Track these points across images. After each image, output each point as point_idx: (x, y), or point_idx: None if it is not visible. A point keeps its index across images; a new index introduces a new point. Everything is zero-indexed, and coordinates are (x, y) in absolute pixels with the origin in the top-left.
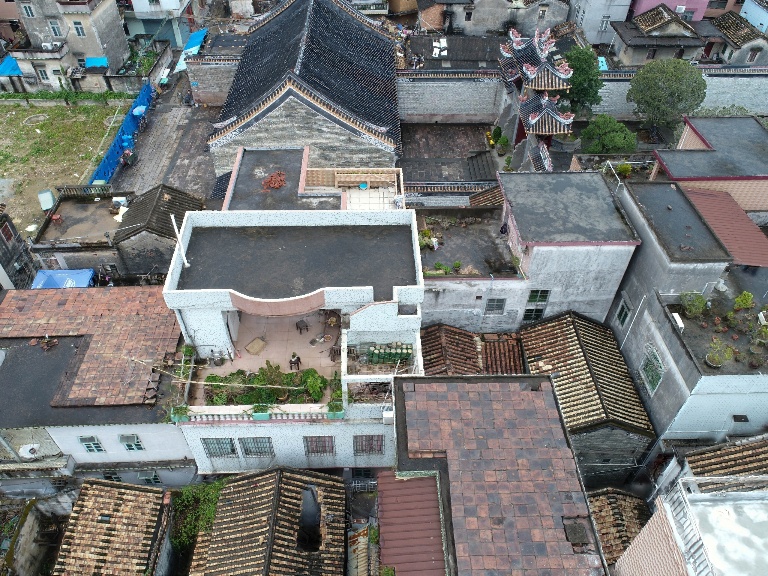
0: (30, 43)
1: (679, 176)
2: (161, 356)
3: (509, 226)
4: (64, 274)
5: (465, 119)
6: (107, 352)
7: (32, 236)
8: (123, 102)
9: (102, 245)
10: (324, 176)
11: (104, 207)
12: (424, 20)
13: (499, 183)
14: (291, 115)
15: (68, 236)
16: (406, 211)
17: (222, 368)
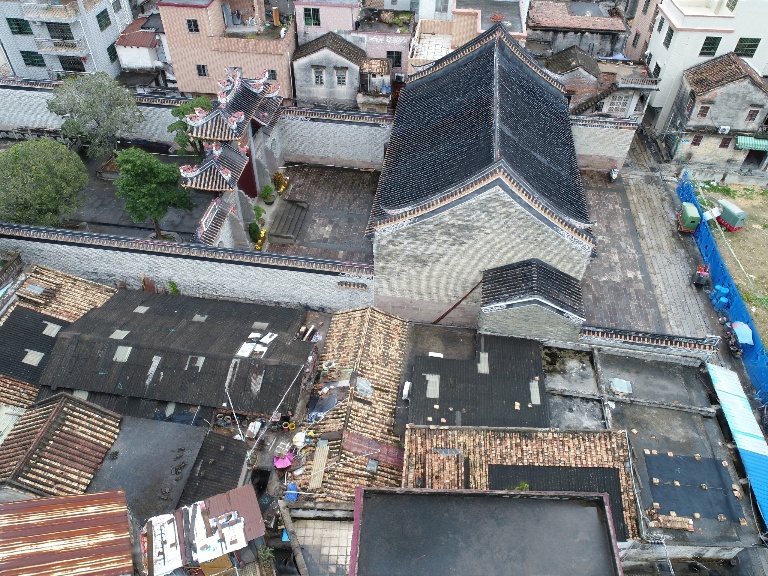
0: None
1: None
2: (534, 8)
3: None
4: None
5: None
6: None
7: None
8: None
9: None
10: None
11: None
12: None
13: None
14: None
15: (629, 69)
16: None
17: None
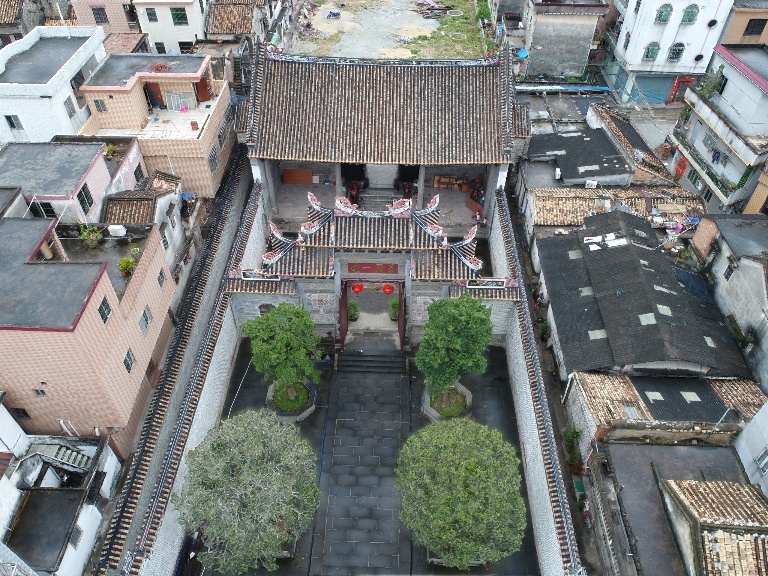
0: None
1: (2, 221)
2: None
3: None
4: None
5: None
6: None
7: None
8: None
9: None
10: None
11: None
12: (699, 230)
13: None
14: None
15: (205, 49)
16: (48, 82)
17: None
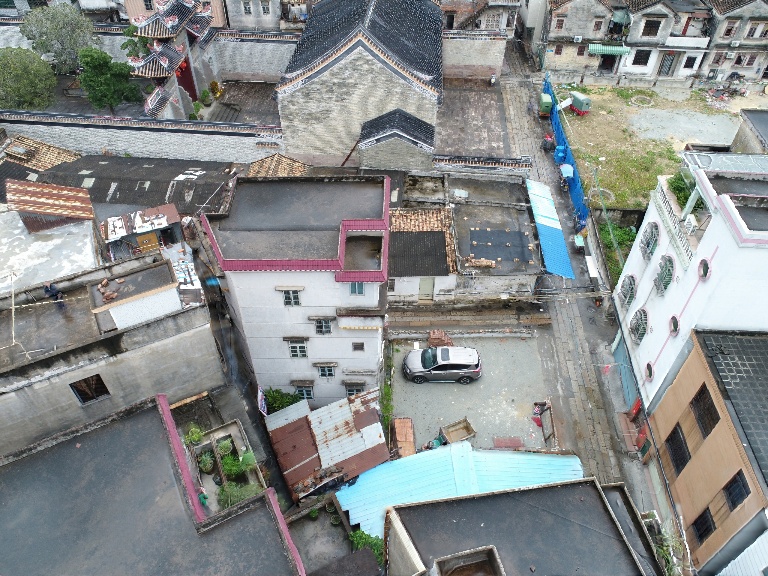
0: None
1: None
2: None
3: None
4: None
5: None
6: None
7: None
8: None
9: None
10: None
11: None
12: None
13: None
14: None
15: None
16: None
17: None
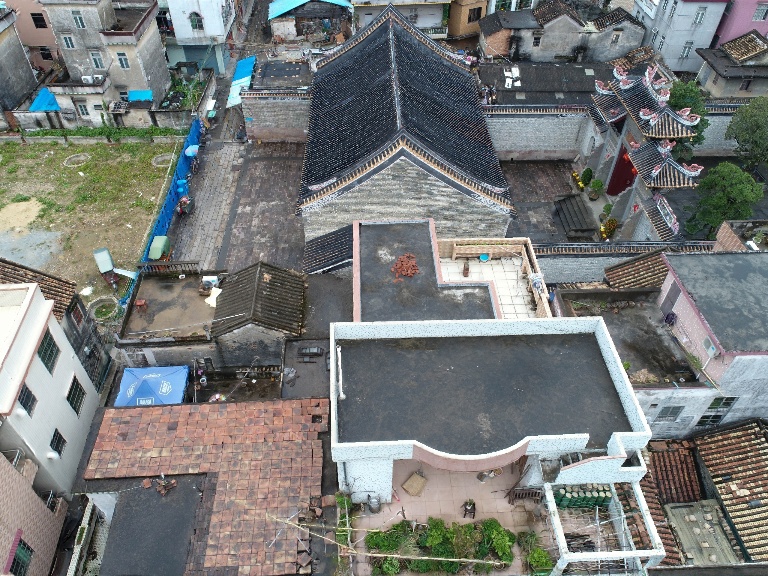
0: (69, 76)
1: None
2: (306, 503)
3: (676, 315)
4: (156, 374)
5: (543, 156)
6: (239, 498)
7: (89, 301)
8: (170, 139)
9: (199, 339)
10: (440, 247)
11: (191, 287)
12: (489, 46)
13: (669, 268)
14: (399, 176)
15: (156, 326)
16: (592, 319)
17: (380, 516)
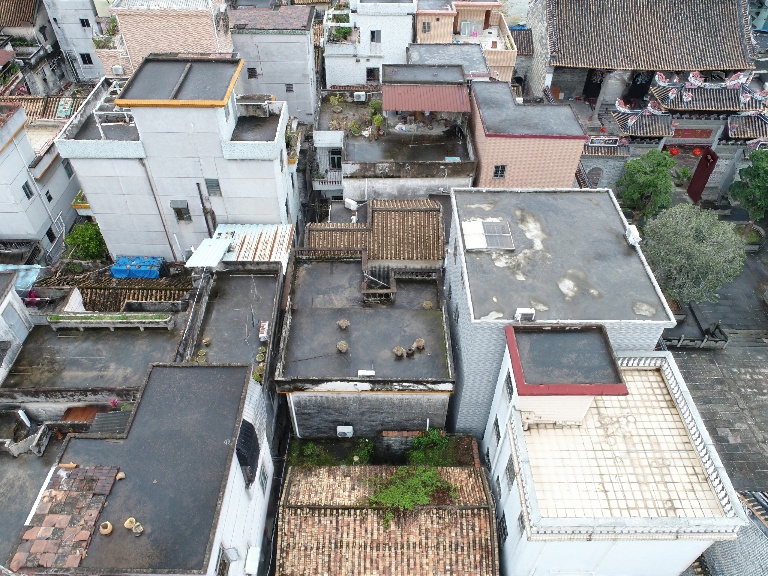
0: None
1: (473, 83)
2: None
3: None
4: None
5: None
6: None
7: None
8: None
9: None
10: None
11: None
12: None
13: None
14: None
15: None
16: (415, 2)
17: None
